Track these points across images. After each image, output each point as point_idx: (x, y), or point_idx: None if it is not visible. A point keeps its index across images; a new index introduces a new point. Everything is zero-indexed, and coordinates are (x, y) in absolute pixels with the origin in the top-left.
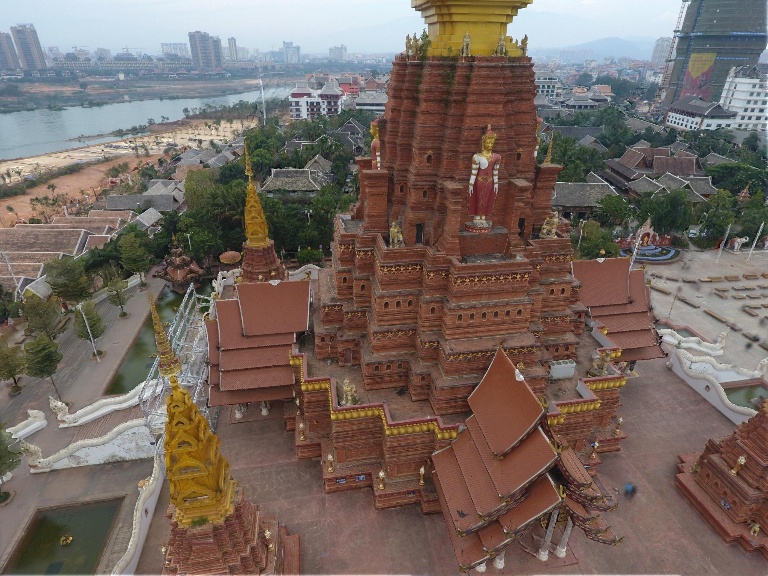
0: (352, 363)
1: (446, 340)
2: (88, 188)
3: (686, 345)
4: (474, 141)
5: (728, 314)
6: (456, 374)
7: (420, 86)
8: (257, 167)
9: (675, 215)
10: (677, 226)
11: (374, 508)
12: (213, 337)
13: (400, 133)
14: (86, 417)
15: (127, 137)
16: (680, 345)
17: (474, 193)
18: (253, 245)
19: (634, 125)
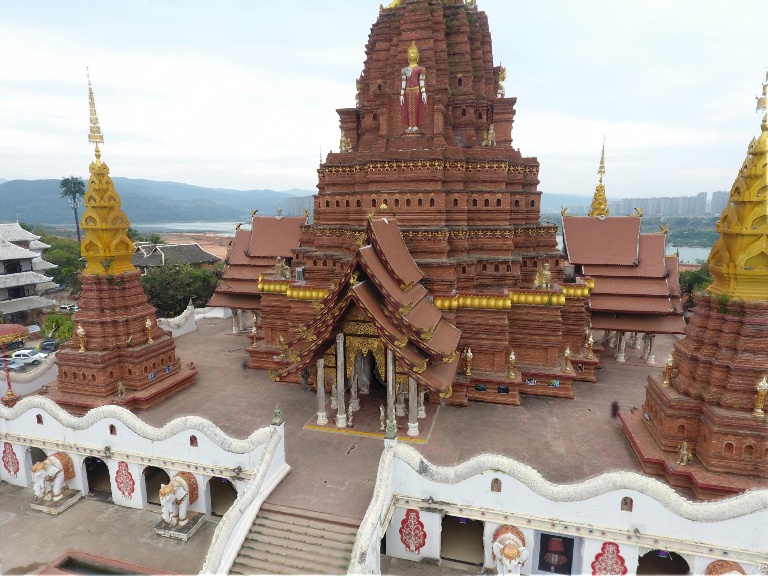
0: None
1: None
2: None
3: None
4: None
5: None
6: None
7: None
8: None
9: None
10: None
11: None
12: None
13: None
14: None
15: None
16: None
17: None
18: None
19: None
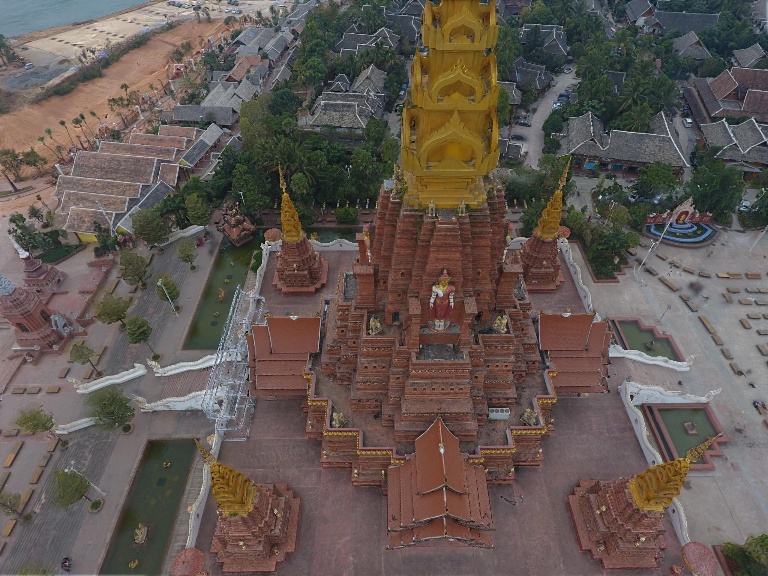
0: (347, 383)
1: (405, 399)
2: (156, 67)
3: (653, 362)
4: (434, 275)
5: (722, 323)
6: (410, 421)
7: (397, 222)
8: (310, 81)
9: (722, 196)
10: (721, 207)
11: (352, 484)
12: (251, 347)
13: (383, 248)
14: (172, 371)
15: None
16: (647, 362)
17: (434, 307)
18: (289, 240)
19: (762, 10)
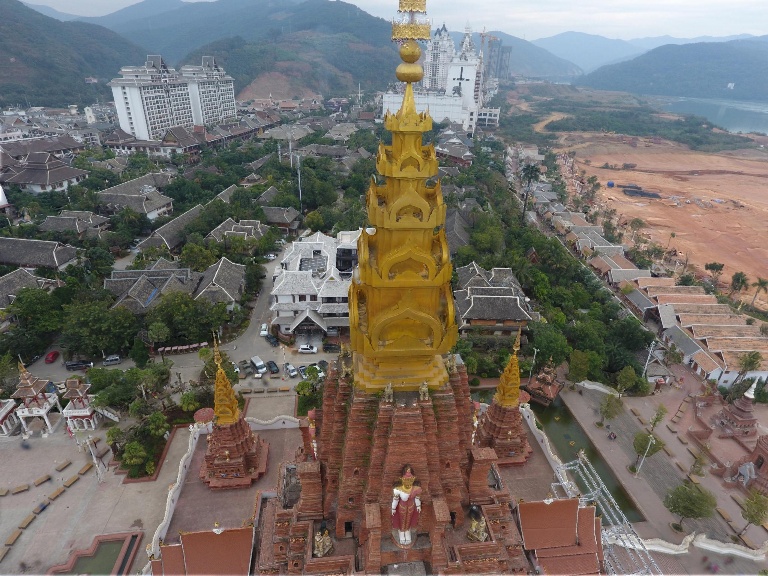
0: None
1: None
2: None
3: None
4: None
5: None
6: None
7: None
8: None
9: None
10: None
11: None
12: None
13: None
14: None
15: None
16: None
17: None
18: None
19: None
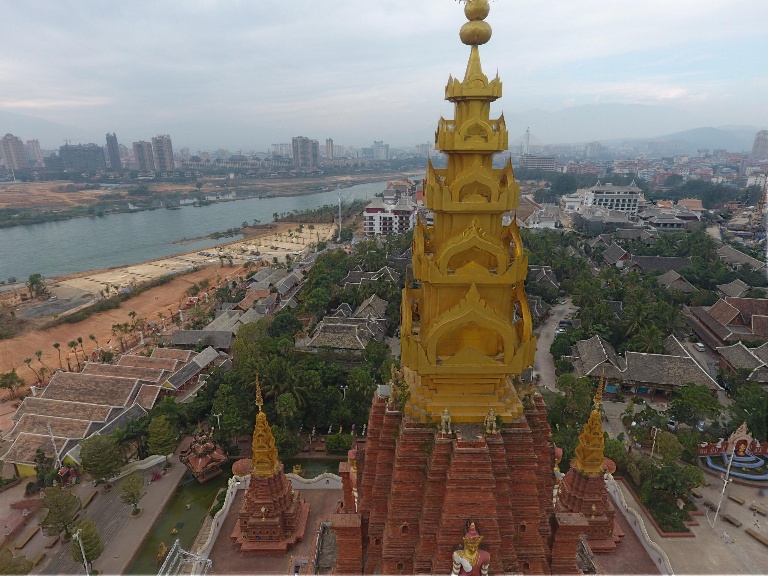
0: None
1: None
2: (172, 301)
3: None
4: (455, 532)
5: None
6: None
7: (396, 444)
8: (313, 308)
9: None
10: None
11: None
12: None
13: (375, 484)
14: None
15: (217, 246)
16: None
17: None
18: (259, 473)
19: (728, 255)
